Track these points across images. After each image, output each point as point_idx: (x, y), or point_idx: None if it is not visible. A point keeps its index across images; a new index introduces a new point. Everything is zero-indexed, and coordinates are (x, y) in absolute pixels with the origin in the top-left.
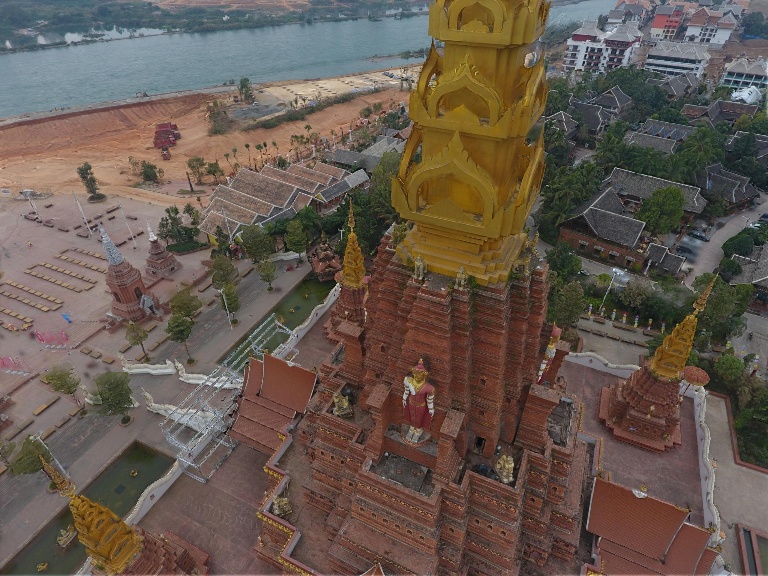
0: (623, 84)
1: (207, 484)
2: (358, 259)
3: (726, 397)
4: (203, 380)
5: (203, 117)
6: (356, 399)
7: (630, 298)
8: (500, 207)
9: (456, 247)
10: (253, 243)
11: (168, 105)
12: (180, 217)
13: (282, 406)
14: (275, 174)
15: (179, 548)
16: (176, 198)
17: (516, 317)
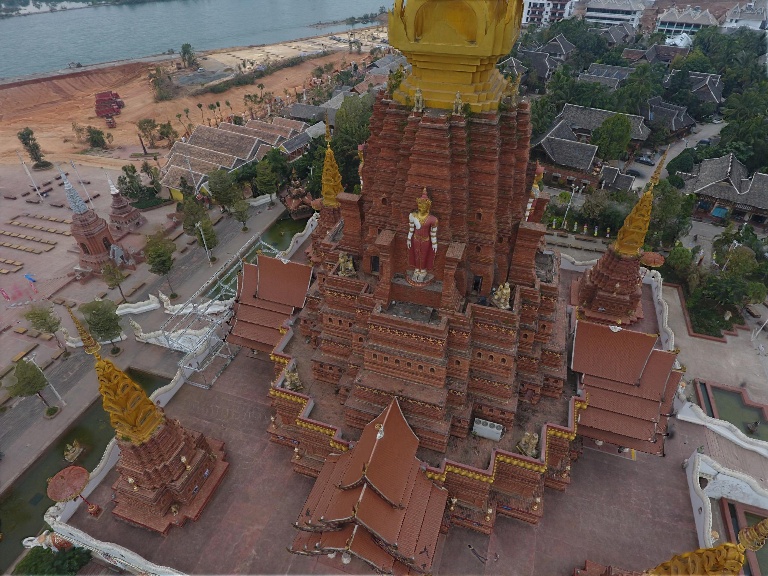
0: (566, 33)
1: (211, 389)
2: (336, 176)
3: (678, 286)
4: (190, 308)
5: (147, 83)
6: (358, 267)
7: (589, 210)
8: (492, 22)
9: (450, 81)
10: (222, 188)
11: (105, 75)
12: (138, 175)
13: (280, 305)
14: (233, 130)
15: (196, 433)
16: (129, 162)
17: (506, 149)
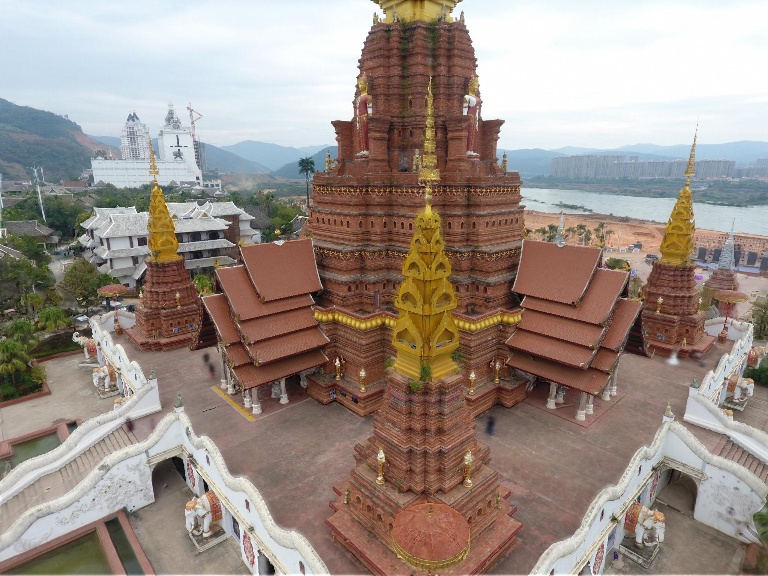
0: None
1: None
2: (673, 223)
3: None
4: None
5: None
6: None
7: None
8: None
9: None
10: None
11: None
12: None
13: None
14: None
15: None
16: None
17: None
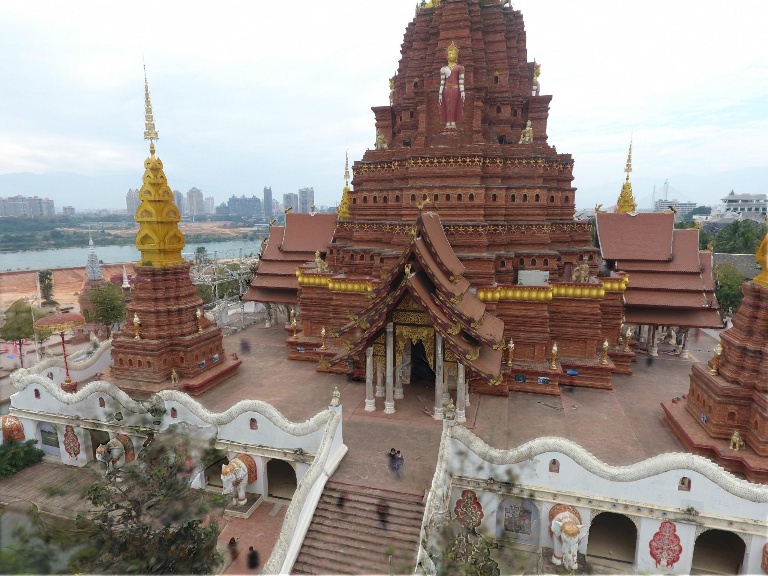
0: None
1: None
2: None
3: None
4: None
5: None
6: None
7: None
8: None
9: None
10: None
11: None
12: None
13: (304, 254)
14: None
15: None
16: None
17: (510, 36)
